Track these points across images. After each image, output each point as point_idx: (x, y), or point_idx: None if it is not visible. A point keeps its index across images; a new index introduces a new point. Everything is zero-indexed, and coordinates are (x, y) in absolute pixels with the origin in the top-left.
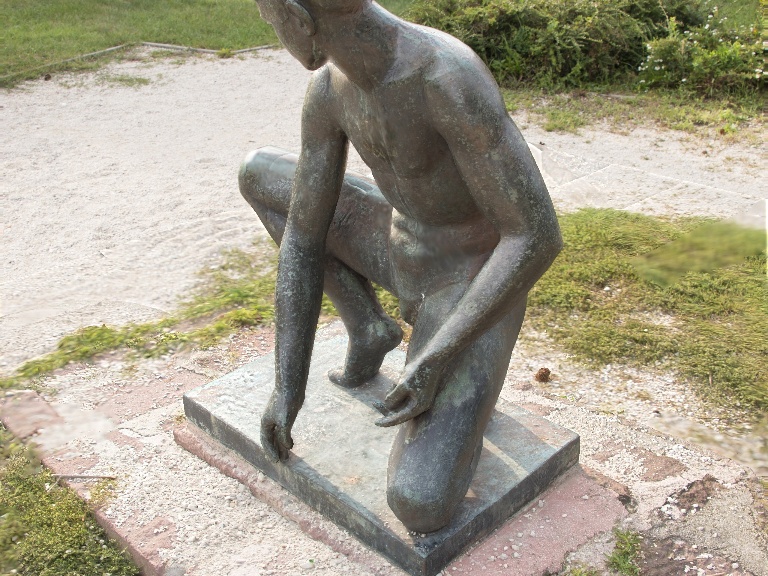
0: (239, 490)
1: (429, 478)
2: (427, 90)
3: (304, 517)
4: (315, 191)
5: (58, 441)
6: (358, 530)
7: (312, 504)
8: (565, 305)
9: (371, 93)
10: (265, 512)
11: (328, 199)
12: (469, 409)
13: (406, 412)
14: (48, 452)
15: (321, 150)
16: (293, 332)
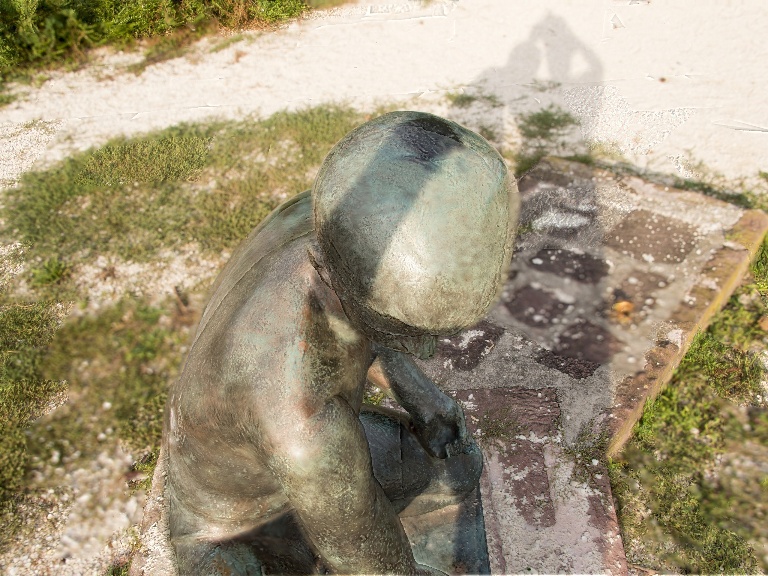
0: None
1: None
2: None
3: None
4: None
5: None
6: None
7: None
8: None
9: None
10: None
11: None
12: None
13: None
14: None
15: None
16: None
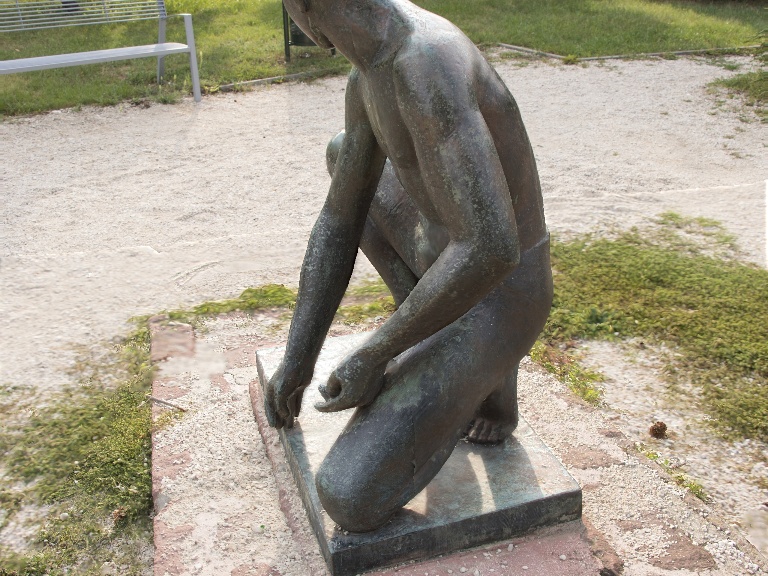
0: (257, 448)
1: (347, 474)
2: (393, 75)
3: (285, 487)
4: (344, 172)
5: (175, 370)
6: (309, 511)
7: (294, 476)
8: (744, 364)
9: (366, 76)
10: (265, 473)
11: (356, 182)
12: (408, 417)
13: (335, 401)
14: (160, 377)
15: (353, 132)
16: (307, 306)
